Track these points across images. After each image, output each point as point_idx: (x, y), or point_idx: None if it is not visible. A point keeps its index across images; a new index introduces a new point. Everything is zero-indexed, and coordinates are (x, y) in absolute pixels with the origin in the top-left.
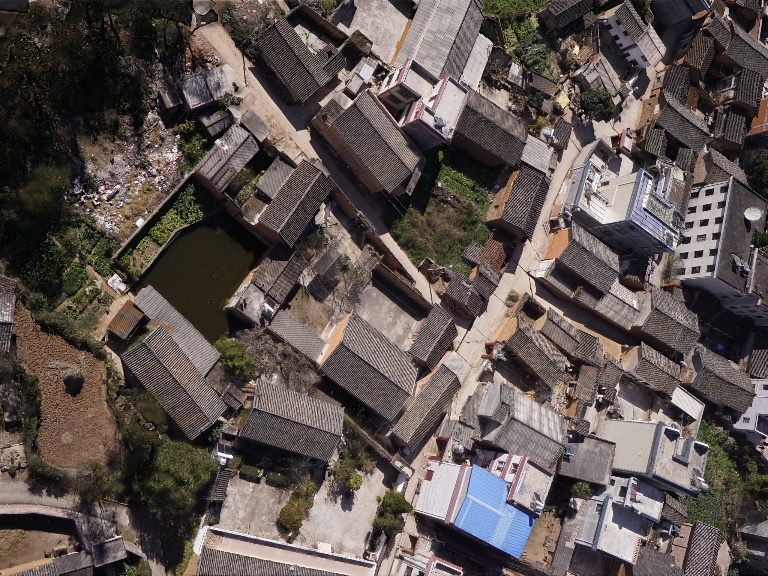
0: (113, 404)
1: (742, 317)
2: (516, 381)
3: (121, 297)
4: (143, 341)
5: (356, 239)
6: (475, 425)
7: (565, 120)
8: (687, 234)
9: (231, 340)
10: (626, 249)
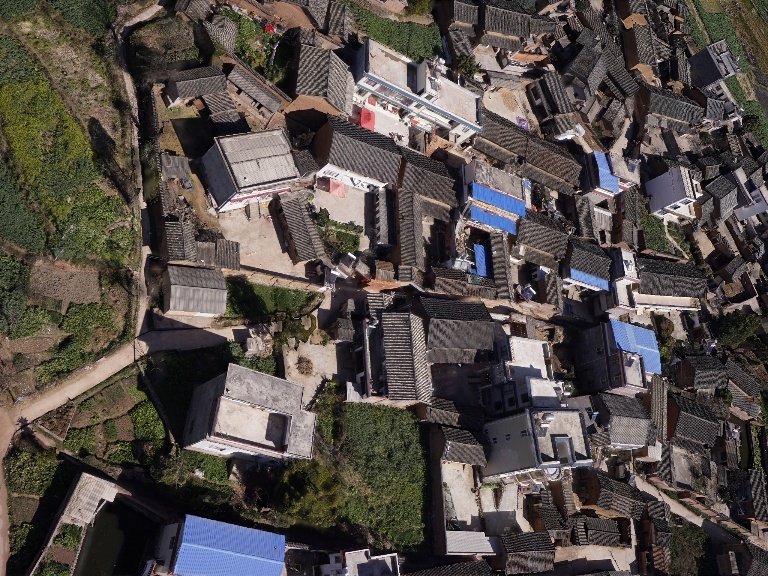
0: None
1: None
2: None
3: None
4: None
5: None
6: None
7: None
8: None
9: None
10: None
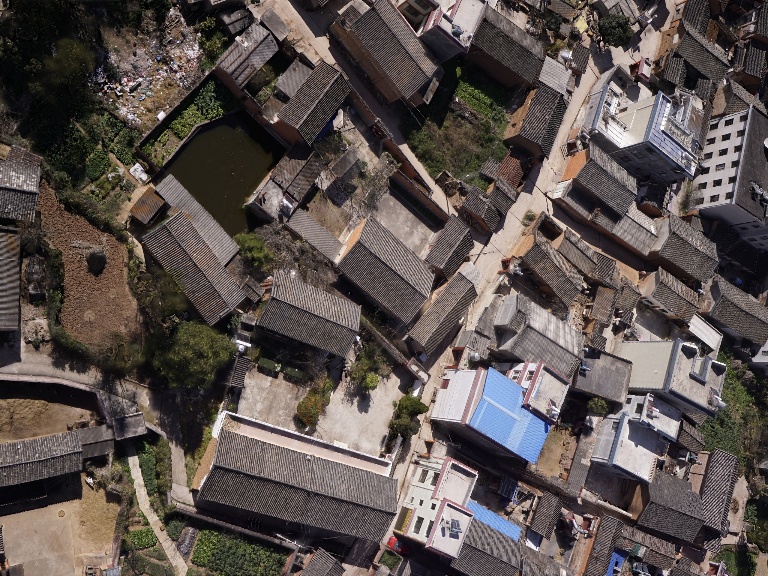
0: (134, 288)
1: (761, 252)
2: (532, 300)
3: (143, 186)
4: (164, 224)
5: (374, 148)
6: (491, 335)
7: (583, 46)
8: (706, 165)
9: (250, 233)
10: (644, 176)
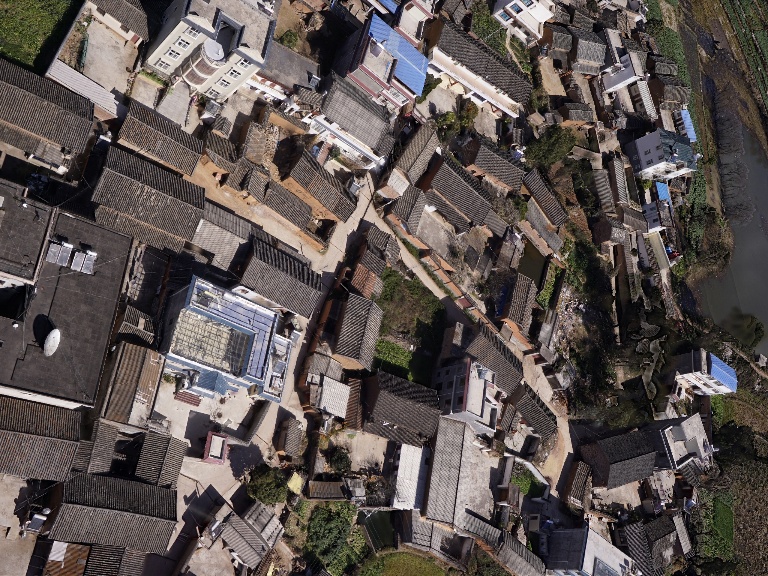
0: None
1: None
2: None
3: None
4: None
5: None
6: None
7: None
8: None
9: None
10: None
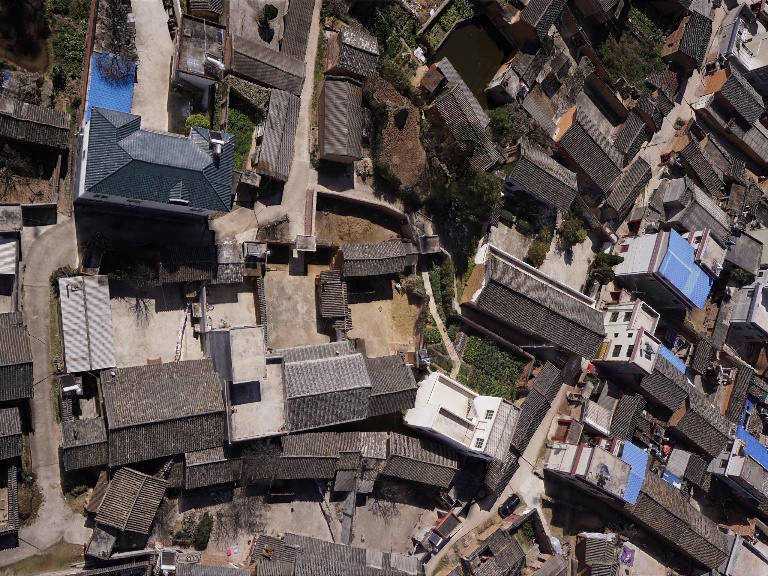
0: None
1: None
2: None
3: (422, 66)
4: (451, 91)
5: (573, 53)
6: (661, 210)
7: None
8: None
9: (499, 108)
10: (763, 98)
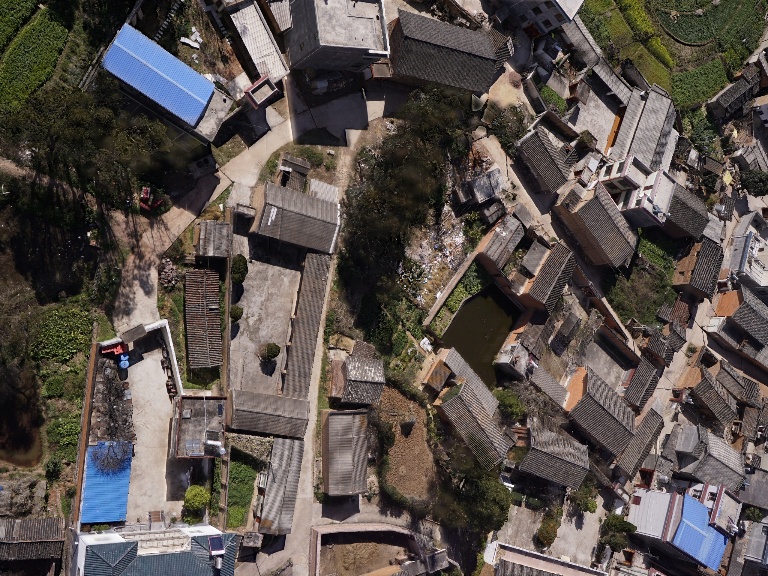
0: None
1: None
2: (694, 420)
3: (428, 356)
4: (459, 394)
5: (582, 303)
6: (674, 459)
7: None
8: None
9: (507, 391)
10: None
